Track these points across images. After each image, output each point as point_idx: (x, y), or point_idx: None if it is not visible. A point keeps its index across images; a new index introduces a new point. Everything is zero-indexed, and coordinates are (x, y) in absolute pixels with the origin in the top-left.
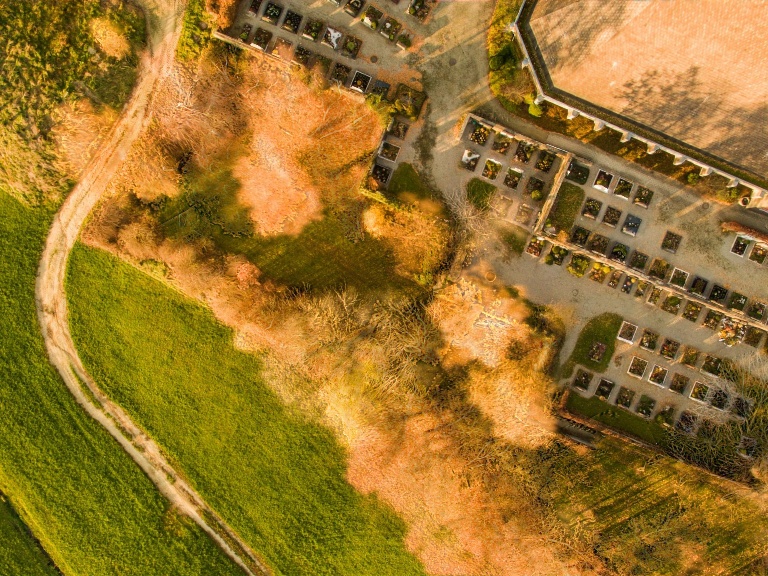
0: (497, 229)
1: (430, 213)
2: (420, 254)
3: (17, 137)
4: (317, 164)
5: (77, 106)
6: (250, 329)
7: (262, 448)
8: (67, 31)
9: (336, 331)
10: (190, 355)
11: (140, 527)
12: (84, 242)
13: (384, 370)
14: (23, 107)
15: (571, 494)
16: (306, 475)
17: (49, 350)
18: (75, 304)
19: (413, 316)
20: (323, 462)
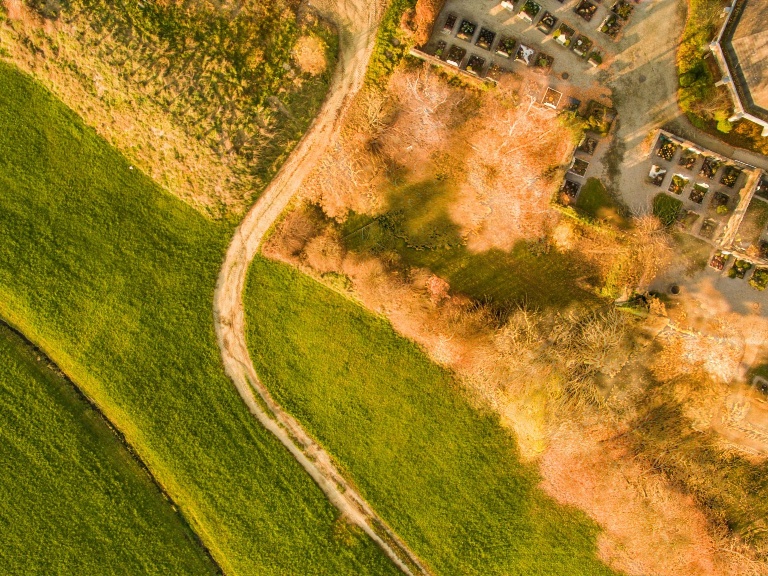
0: (681, 243)
1: (617, 227)
2: (605, 267)
3: (210, 151)
4: (502, 178)
5: (270, 121)
6: (427, 341)
7: (433, 458)
8: (263, 47)
9: (516, 343)
10: (365, 366)
11: (310, 536)
12: (265, 255)
13: (564, 381)
14: (217, 122)
15: (743, 503)
16: (475, 485)
17: (225, 361)
18: (252, 316)
19: (593, 328)
20: (493, 472)
